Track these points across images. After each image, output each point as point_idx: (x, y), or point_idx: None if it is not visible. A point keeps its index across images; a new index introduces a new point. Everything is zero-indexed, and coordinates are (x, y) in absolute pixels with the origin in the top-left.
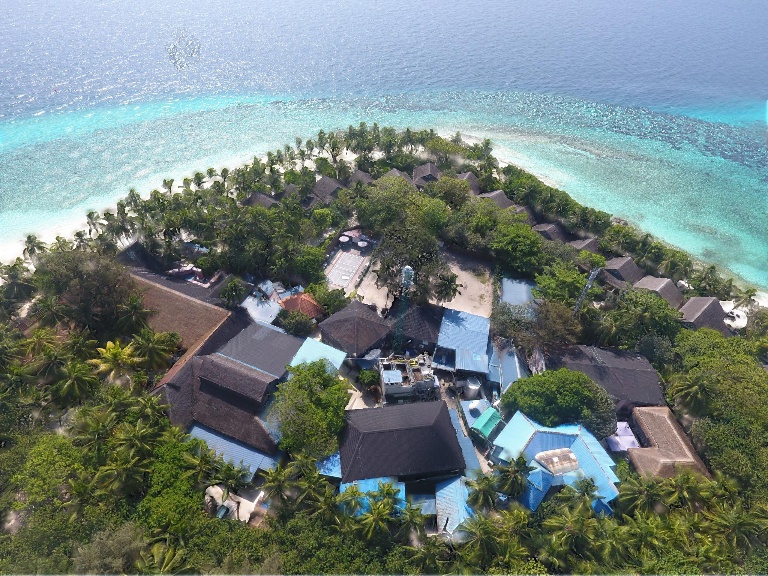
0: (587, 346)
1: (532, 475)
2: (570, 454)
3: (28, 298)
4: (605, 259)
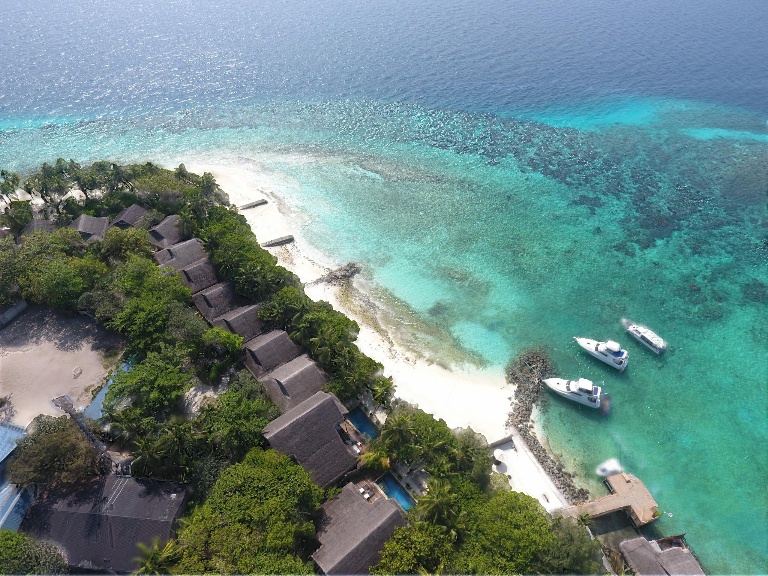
0: (120, 477)
1: None
2: None
3: None
4: (265, 331)
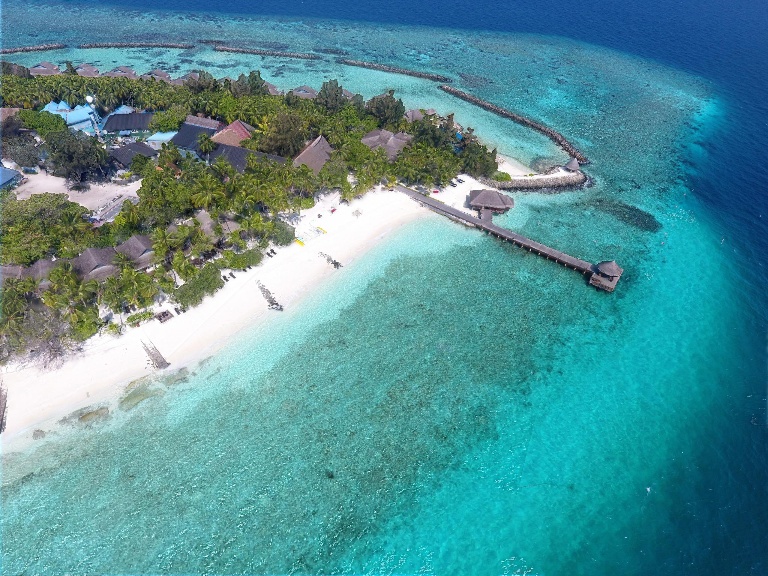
0: None
1: (83, 107)
2: (59, 110)
3: None
4: None
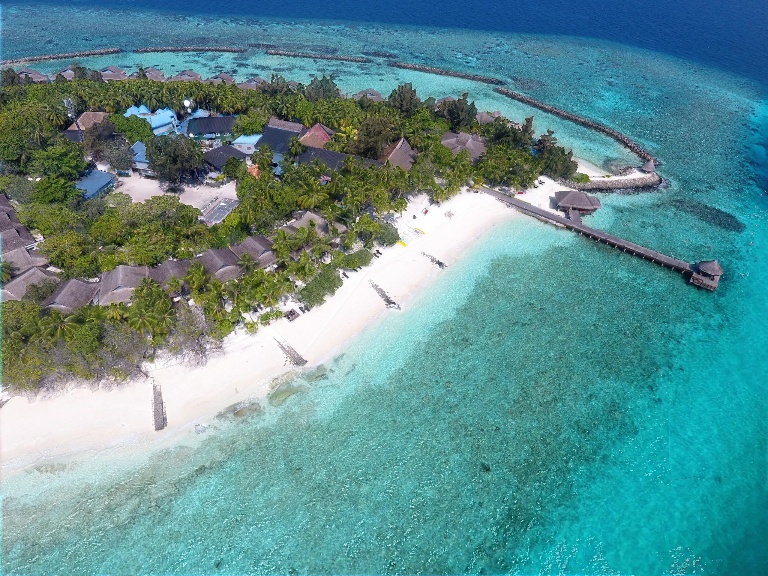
0: None
1: None
2: (141, 114)
3: None
4: None
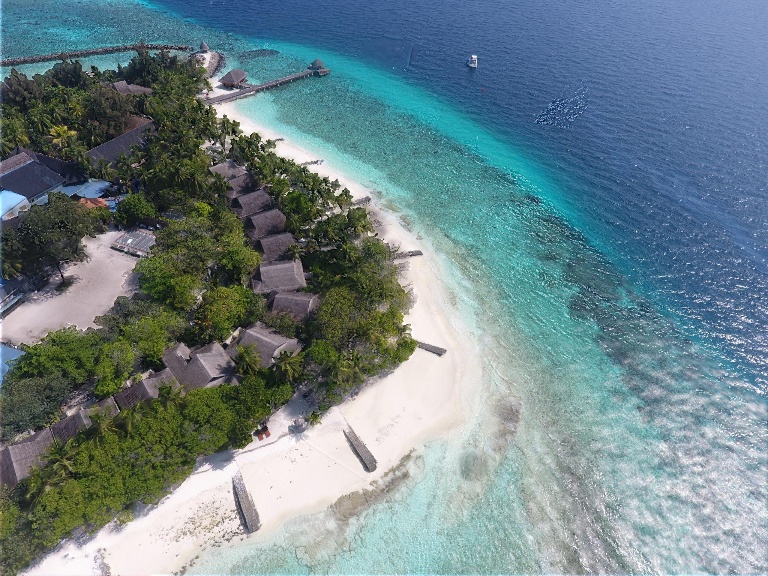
0: None
1: None
2: None
3: (142, 111)
4: None
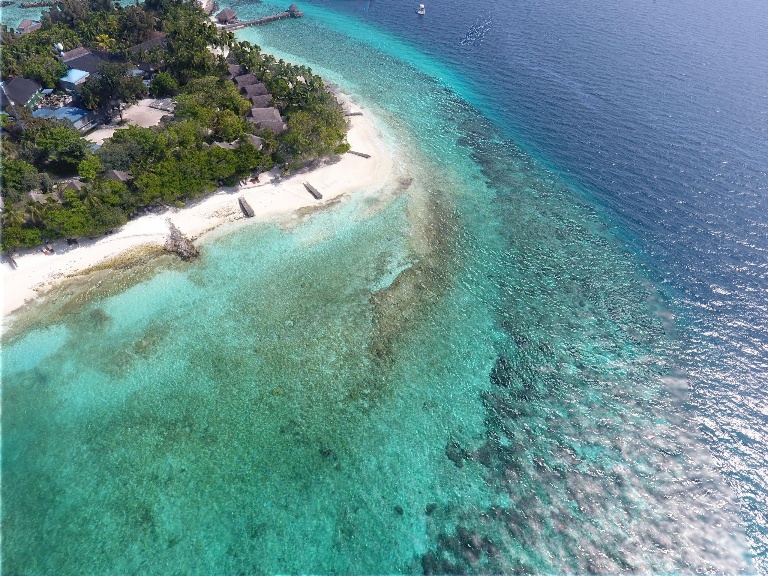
0: None
1: None
2: None
3: None
4: None
